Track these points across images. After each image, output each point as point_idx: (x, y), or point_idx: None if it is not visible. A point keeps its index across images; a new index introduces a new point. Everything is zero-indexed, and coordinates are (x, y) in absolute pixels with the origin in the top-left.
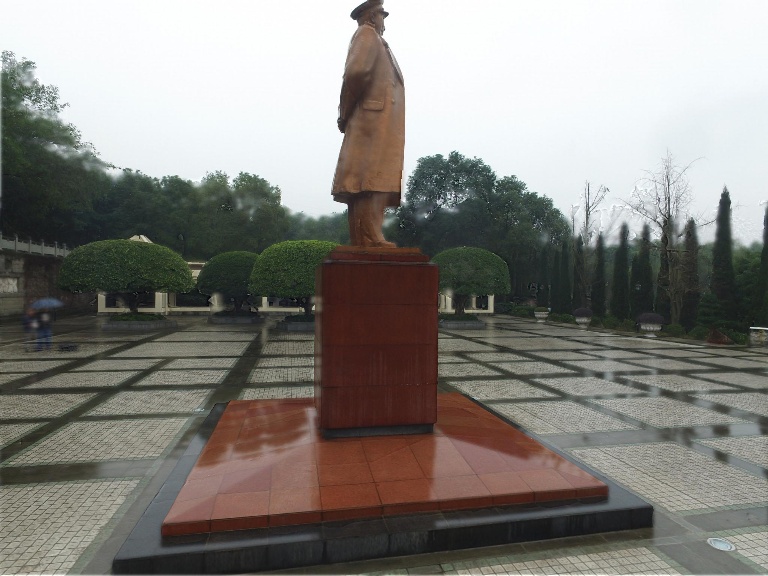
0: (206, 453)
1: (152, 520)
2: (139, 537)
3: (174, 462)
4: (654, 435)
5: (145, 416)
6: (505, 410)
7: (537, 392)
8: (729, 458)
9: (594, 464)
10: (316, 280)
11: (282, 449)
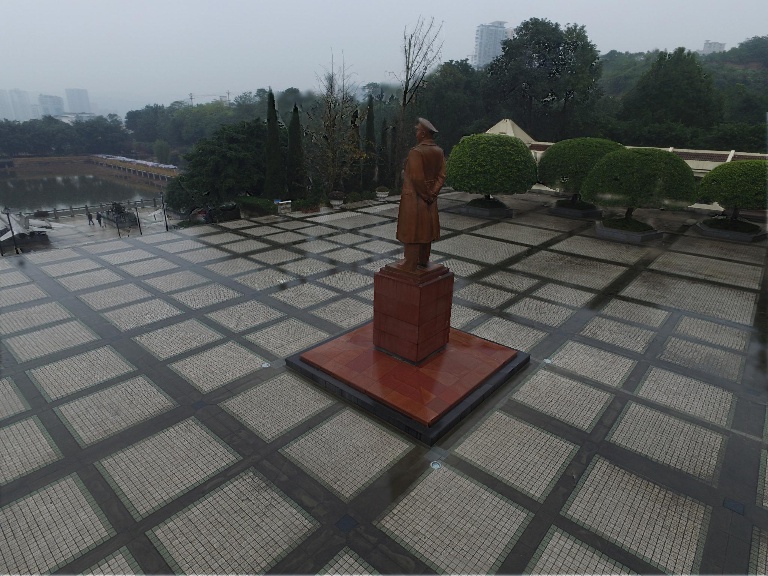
0: (487, 373)
1: (517, 361)
2: (523, 357)
3: (492, 402)
4: (302, 315)
5: (482, 476)
6: (291, 350)
7: (224, 349)
8: (320, 304)
9: (357, 322)
10: (431, 291)
11: (465, 352)
